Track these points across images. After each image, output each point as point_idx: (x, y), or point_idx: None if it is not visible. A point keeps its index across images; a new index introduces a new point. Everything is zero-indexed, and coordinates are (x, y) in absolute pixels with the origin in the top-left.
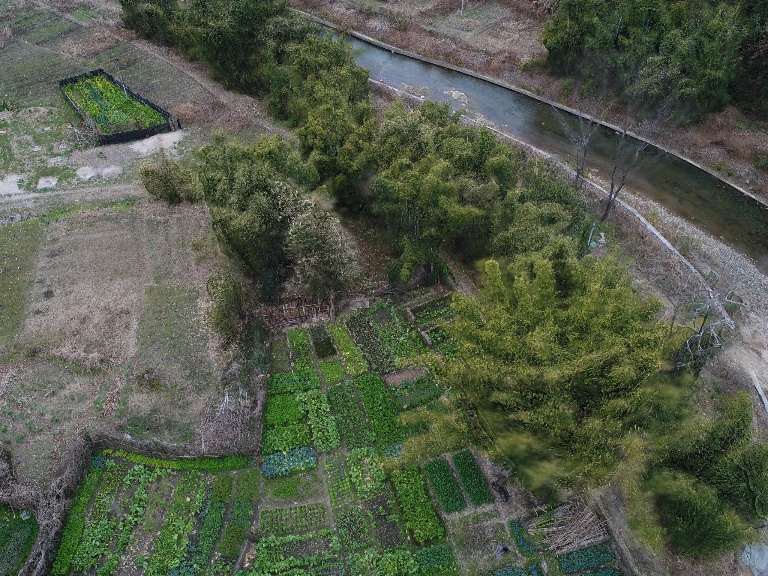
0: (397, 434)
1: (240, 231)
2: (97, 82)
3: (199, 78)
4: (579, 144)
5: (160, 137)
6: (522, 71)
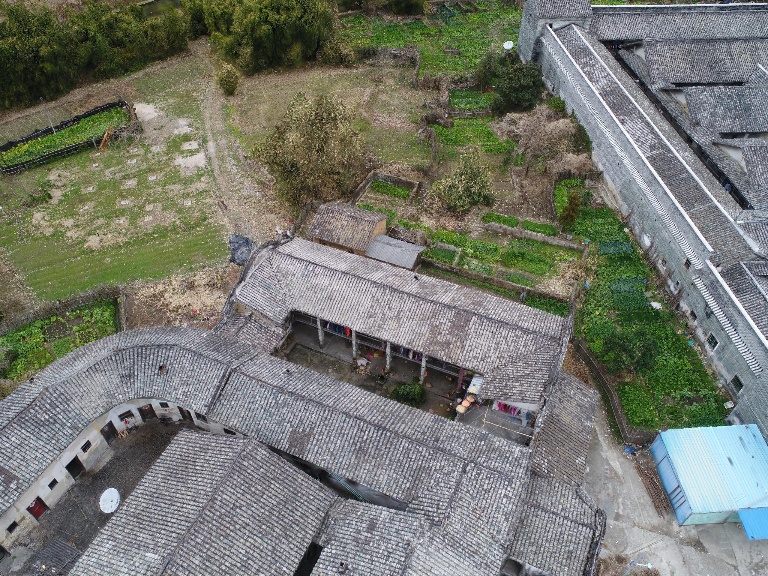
0: (399, 33)
1: (320, 14)
2: (17, 149)
3: (22, 114)
4: (179, 7)
5: (139, 109)
6: (87, 6)
